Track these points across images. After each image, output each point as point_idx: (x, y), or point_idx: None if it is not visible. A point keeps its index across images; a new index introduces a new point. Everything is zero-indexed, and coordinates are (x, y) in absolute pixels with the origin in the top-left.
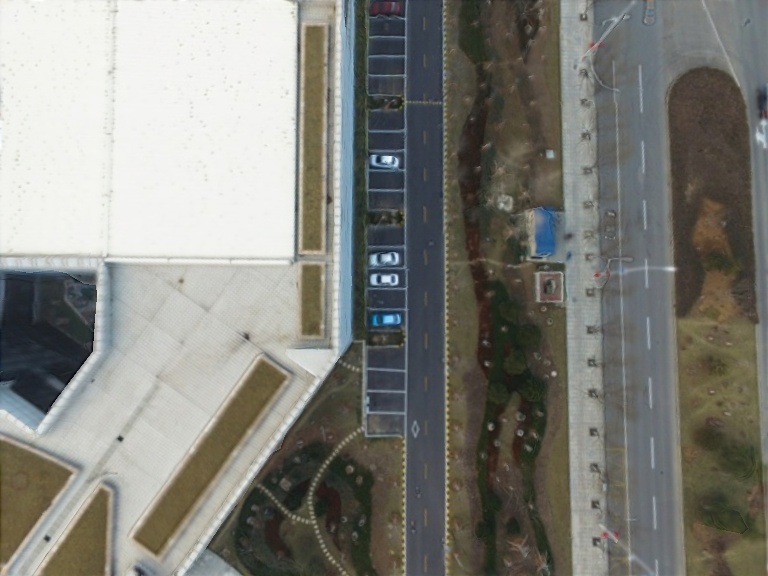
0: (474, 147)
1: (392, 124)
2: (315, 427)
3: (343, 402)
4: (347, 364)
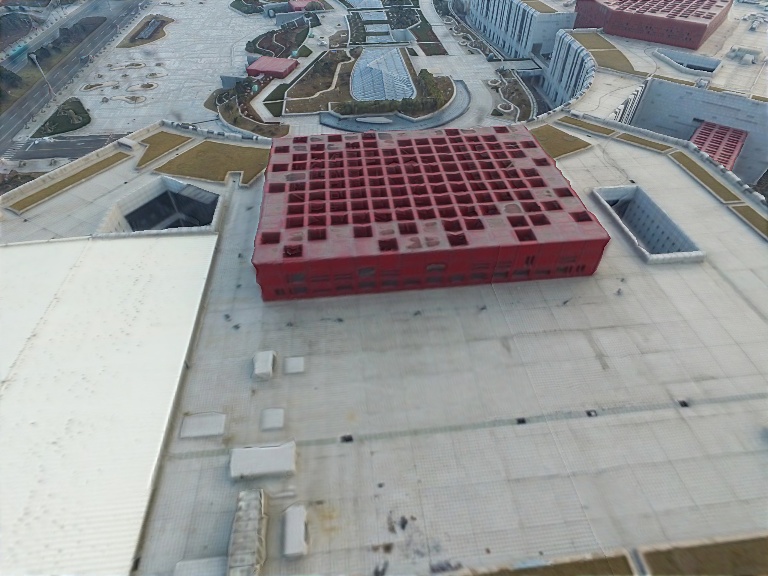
0: None
1: None
2: None
3: None
4: None
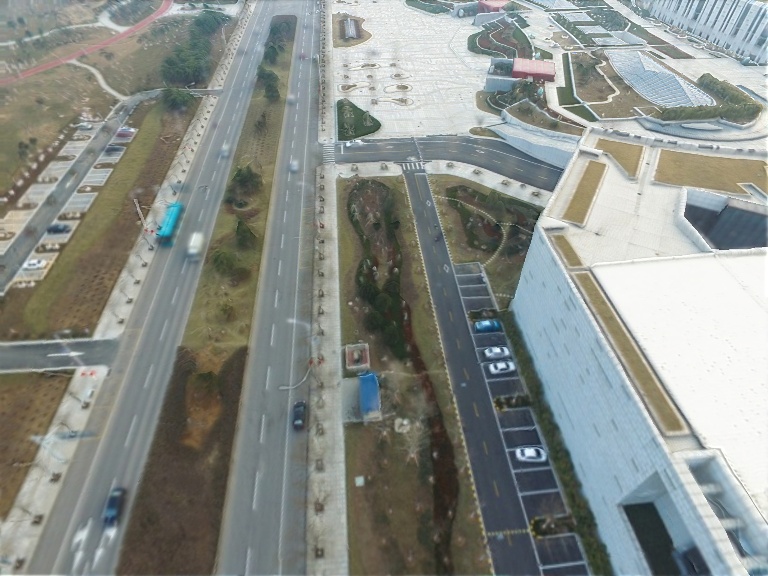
0: (442, 479)
1: (535, 503)
2: (515, 263)
3: (502, 275)
4: (506, 297)
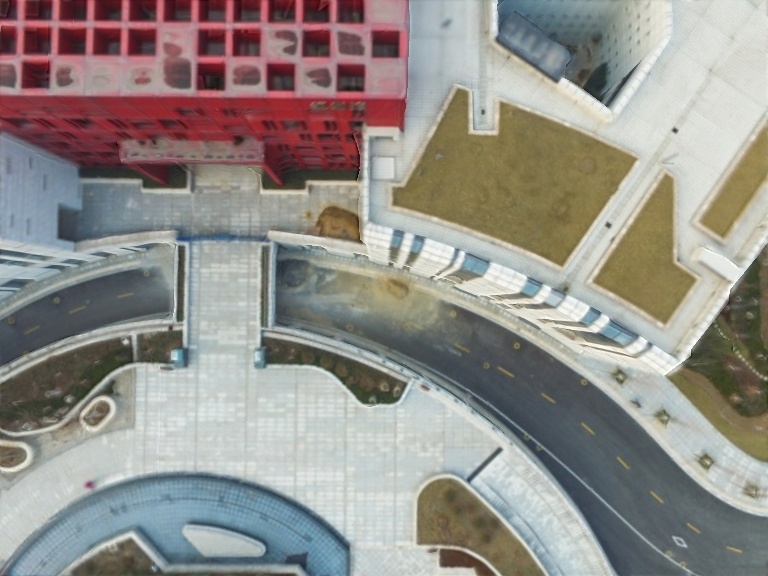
0: None
1: None
2: None
3: None
4: None
